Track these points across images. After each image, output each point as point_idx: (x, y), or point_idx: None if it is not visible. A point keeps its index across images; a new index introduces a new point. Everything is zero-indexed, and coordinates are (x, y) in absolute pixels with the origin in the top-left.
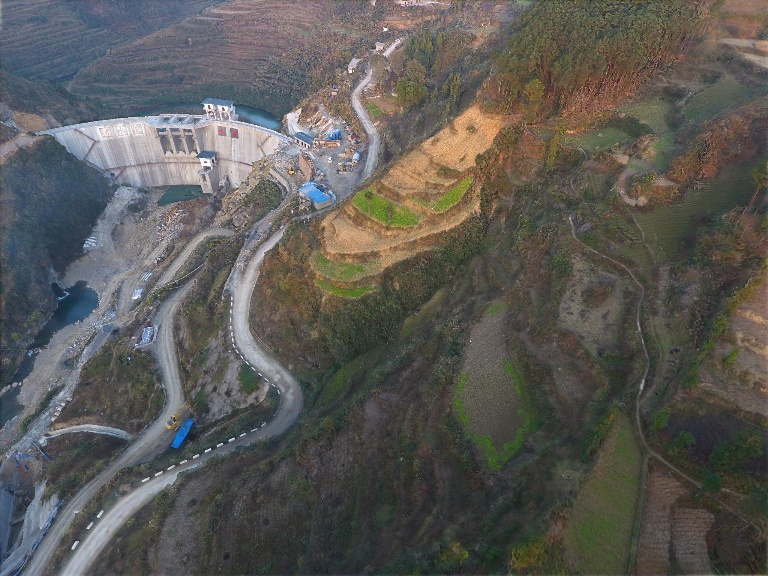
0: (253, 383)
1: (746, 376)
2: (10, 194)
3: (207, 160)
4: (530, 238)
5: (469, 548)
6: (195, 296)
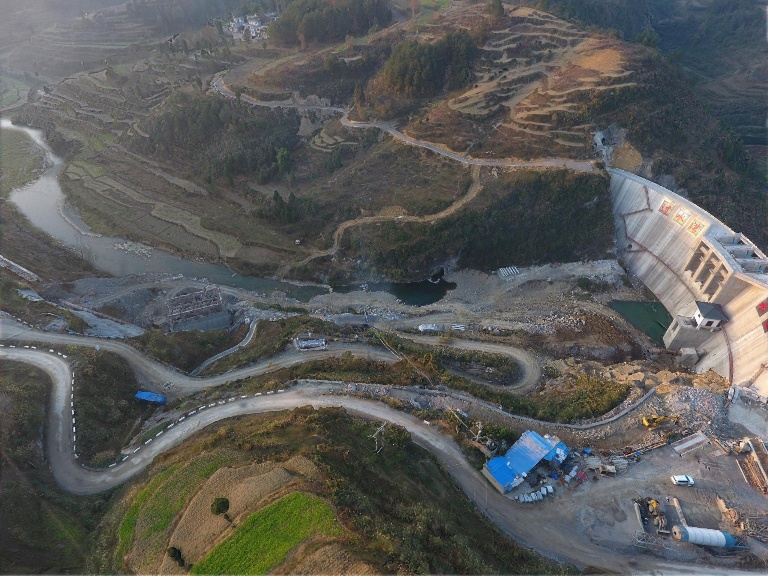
0: (142, 437)
1: None
2: (506, 194)
3: (701, 315)
4: None
5: None
6: (319, 360)
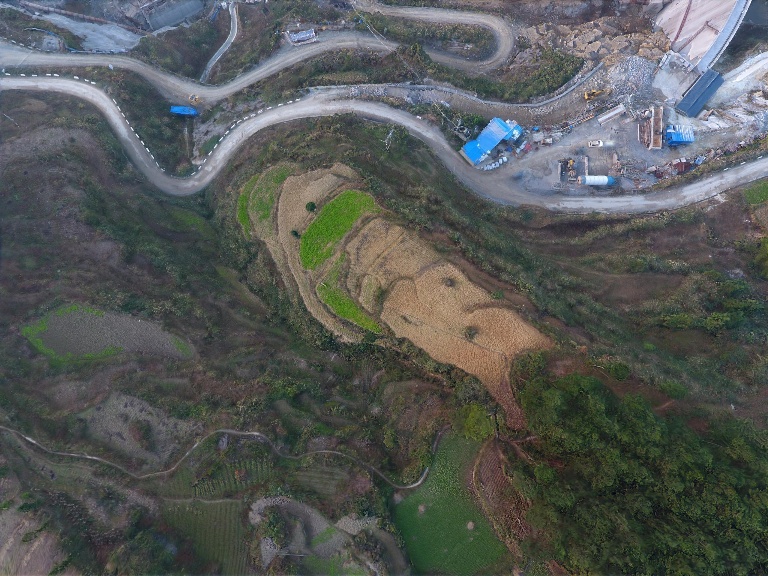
0: (203, 150)
1: (0, 512)
2: None
3: None
4: (266, 391)
5: None
6: (320, 62)
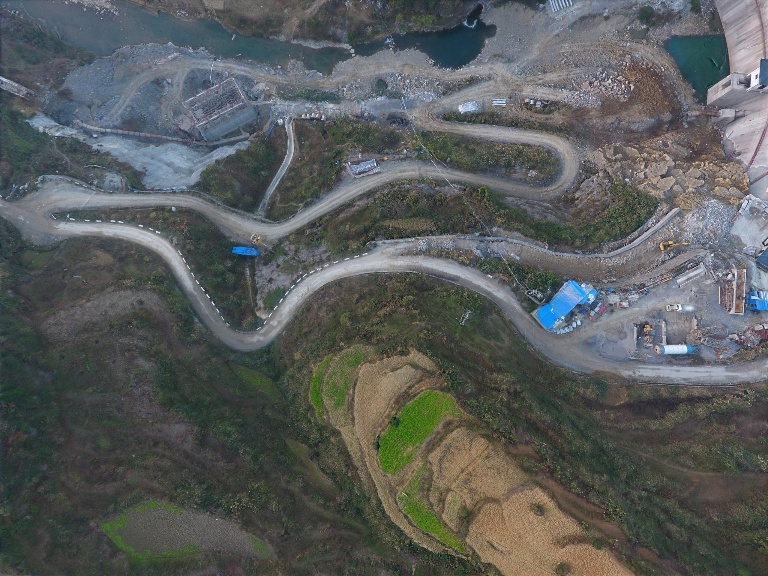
0: (268, 304)
1: None
2: None
3: (759, 79)
4: None
5: (34, 511)
6: (385, 207)
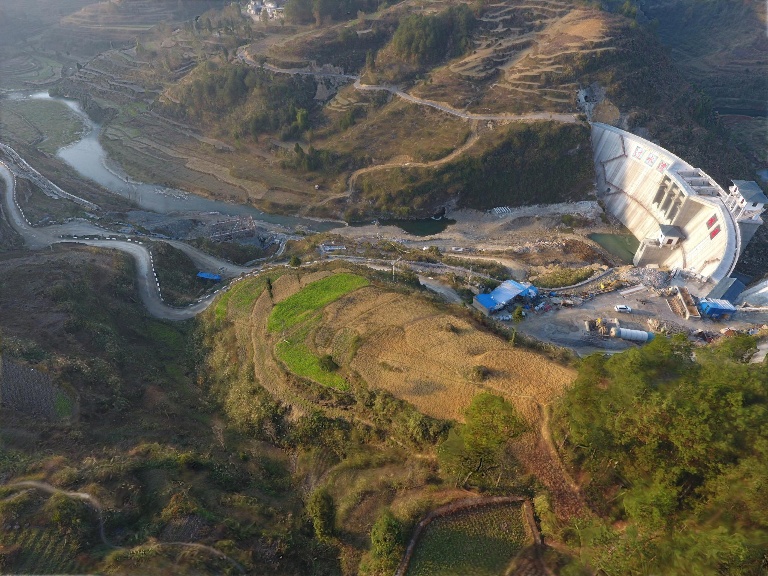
0: None
1: None
2: (500, 142)
3: (663, 235)
4: None
5: None
6: None
